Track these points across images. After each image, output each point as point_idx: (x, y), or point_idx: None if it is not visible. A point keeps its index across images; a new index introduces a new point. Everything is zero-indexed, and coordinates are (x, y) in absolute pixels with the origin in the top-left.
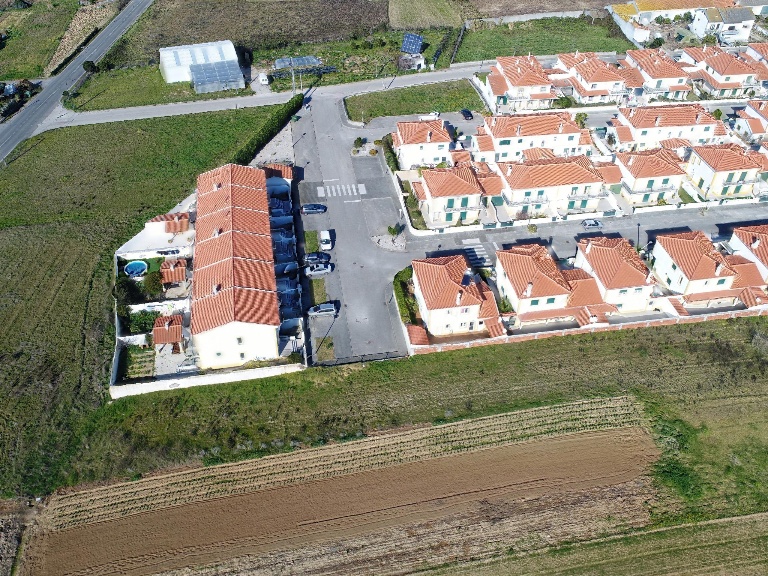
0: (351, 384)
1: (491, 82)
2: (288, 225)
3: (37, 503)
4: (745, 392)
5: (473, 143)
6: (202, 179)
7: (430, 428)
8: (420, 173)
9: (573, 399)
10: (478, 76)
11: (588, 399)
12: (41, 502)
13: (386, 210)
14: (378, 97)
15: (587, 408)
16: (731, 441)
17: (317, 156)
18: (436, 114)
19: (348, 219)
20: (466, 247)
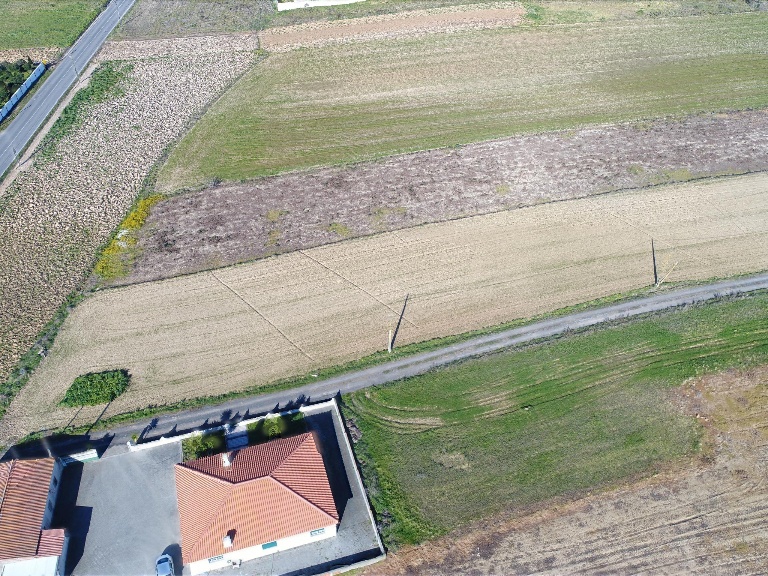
0: (389, 3)
1: None
2: None
3: (260, 31)
4: (569, 1)
5: None
6: None
7: (426, 10)
8: None
9: (490, 2)
10: None
11: (497, 2)
12: (262, 31)
13: None
14: None
15: (496, 4)
16: (559, 10)
17: None
18: None
19: None
20: None
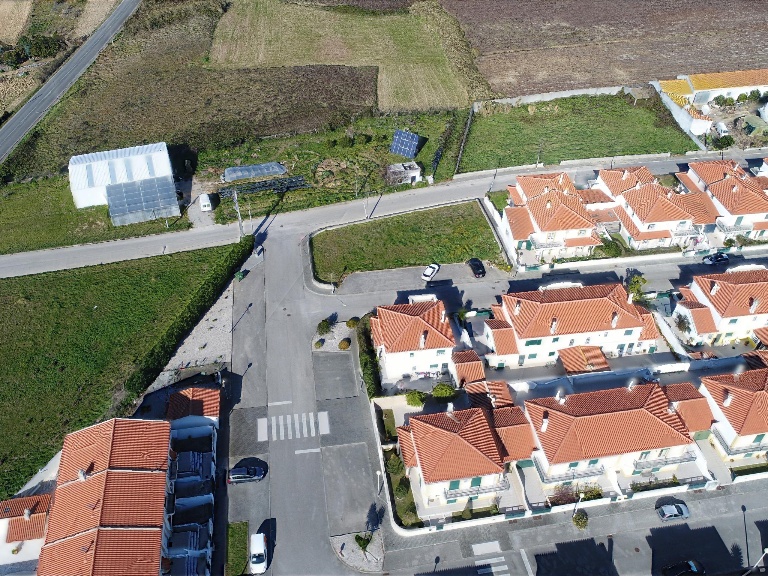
0: None
1: (510, 219)
2: (205, 509)
3: None
4: None
5: (486, 334)
6: (69, 445)
7: None
8: (409, 402)
9: None
10: (491, 197)
11: None
12: None
13: (357, 472)
14: (357, 234)
15: None
16: None
17: (264, 351)
18: (434, 270)
19: (298, 494)
20: (478, 562)
